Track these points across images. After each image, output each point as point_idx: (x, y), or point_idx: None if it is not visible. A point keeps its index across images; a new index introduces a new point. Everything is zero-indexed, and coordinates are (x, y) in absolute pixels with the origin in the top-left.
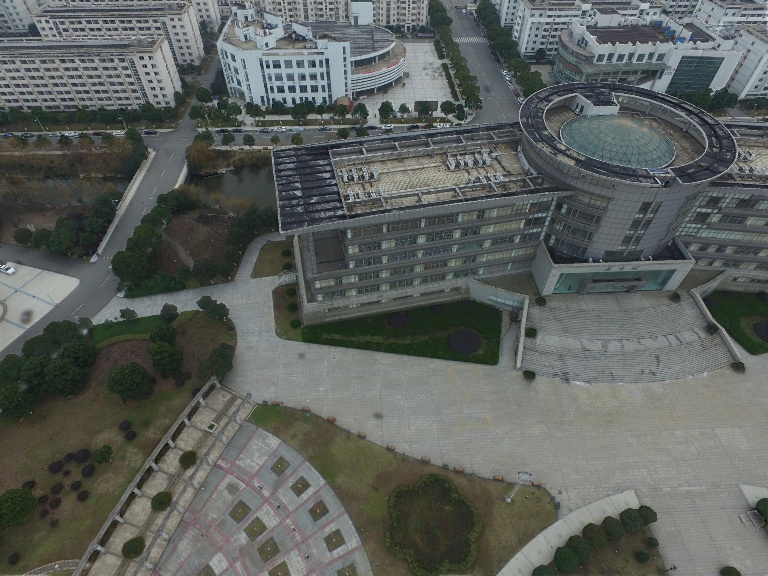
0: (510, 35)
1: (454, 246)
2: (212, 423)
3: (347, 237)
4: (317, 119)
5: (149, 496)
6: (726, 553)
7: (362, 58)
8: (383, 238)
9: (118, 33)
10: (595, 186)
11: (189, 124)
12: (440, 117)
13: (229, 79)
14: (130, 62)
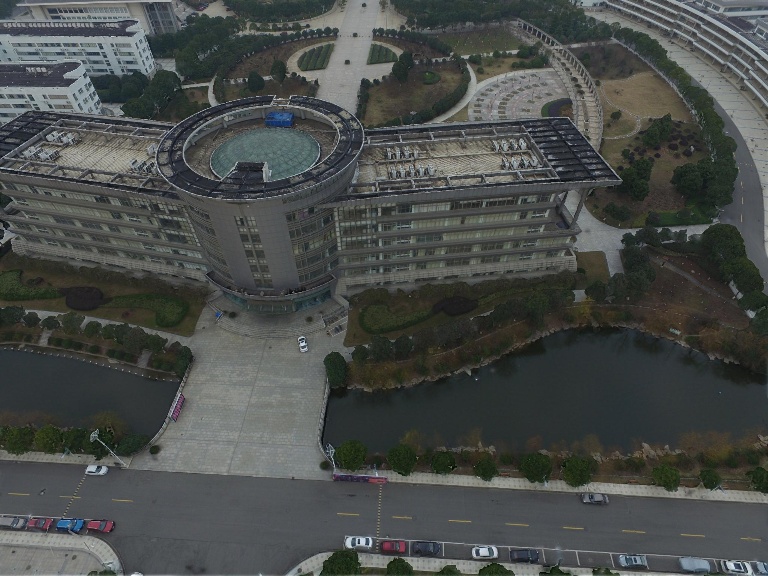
0: None
1: None
2: None
3: None
4: None
5: None
6: None
7: None
8: None
9: None
10: None
11: None
12: None
13: None
14: None
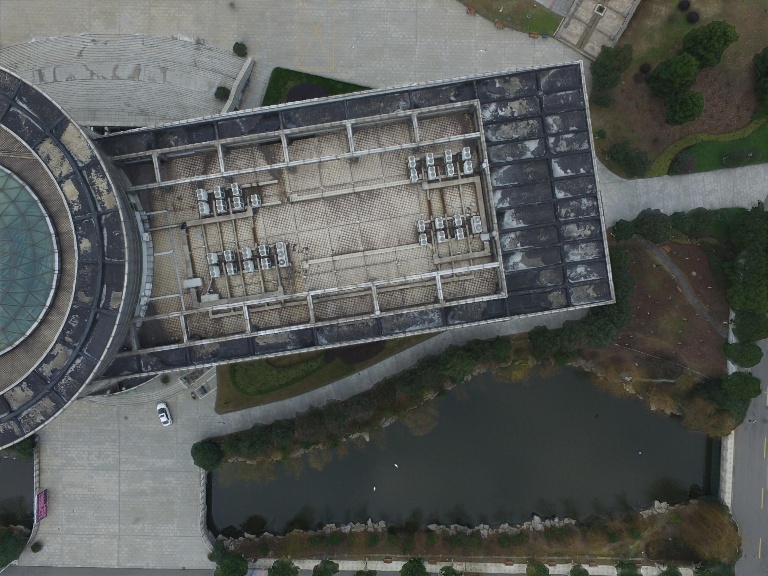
0: None
1: None
2: (600, 13)
3: None
4: None
5: None
6: None
7: None
8: None
9: None
10: None
11: None
12: None
13: None
14: None
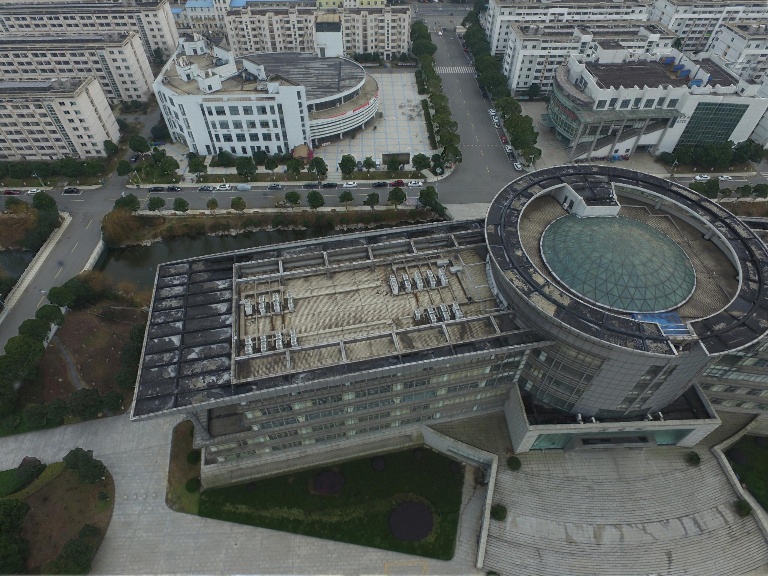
0: (500, 67)
1: (396, 397)
2: None
3: (240, 404)
4: (269, 173)
5: None
6: None
7: (324, 100)
8: (292, 402)
9: (51, 67)
10: (584, 341)
11: (120, 179)
12: (413, 171)
13: (171, 123)
14: (49, 108)
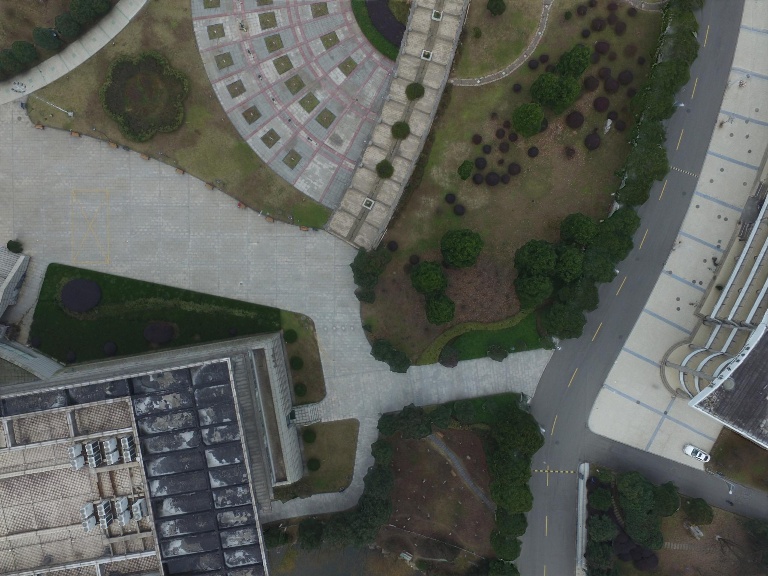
0: None
1: None
2: (368, 207)
3: None
4: None
5: (415, 137)
6: None
7: None
8: None
9: None
10: None
11: None
12: None
13: None
14: None
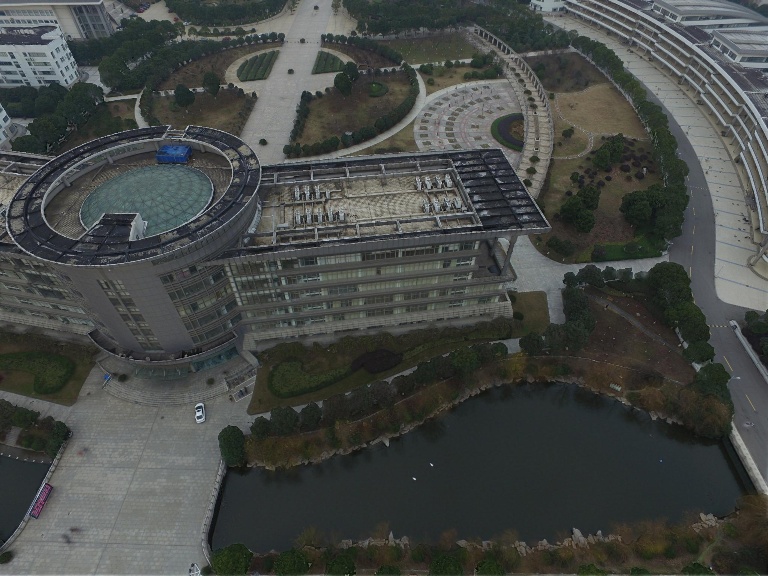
0: None
1: None
2: None
3: None
4: None
5: (540, 174)
6: (258, 148)
7: None
8: None
9: None
10: None
11: None
12: None
13: None
14: None
